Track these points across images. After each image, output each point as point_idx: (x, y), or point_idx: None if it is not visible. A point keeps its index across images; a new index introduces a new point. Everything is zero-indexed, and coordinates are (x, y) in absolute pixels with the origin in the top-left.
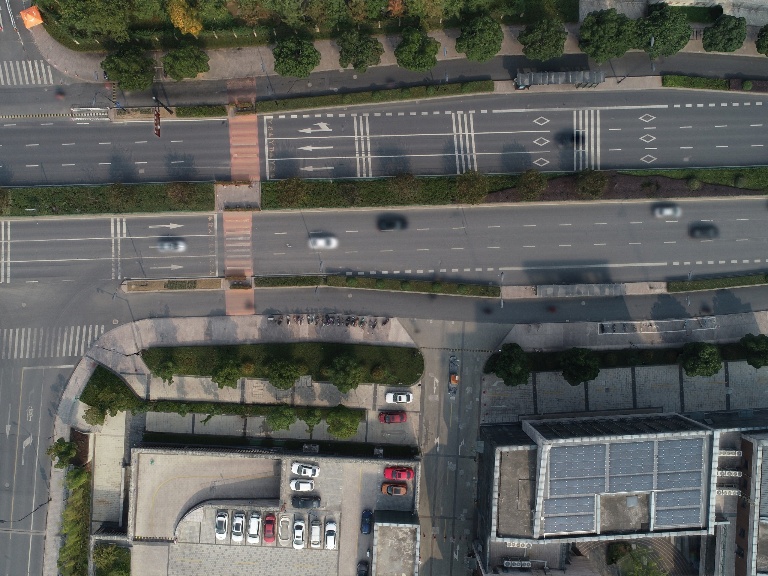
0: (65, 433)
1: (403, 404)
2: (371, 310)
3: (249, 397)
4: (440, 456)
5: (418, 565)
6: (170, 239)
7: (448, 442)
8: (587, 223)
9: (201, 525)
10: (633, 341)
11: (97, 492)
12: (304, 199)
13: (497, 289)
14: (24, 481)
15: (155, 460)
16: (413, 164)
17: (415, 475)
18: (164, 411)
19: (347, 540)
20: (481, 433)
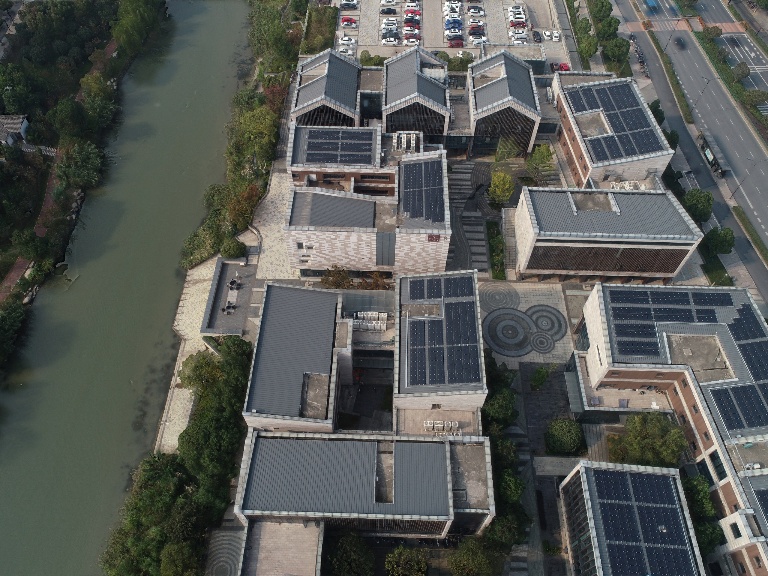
0: None
1: None
2: (652, 73)
3: None
4: None
5: None
6: (660, 5)
7: None
8: (759, 165)
9: (513, 5)
10: (687, 190)
11: None
12: (707, 45)
13: (693, 120)
14: None
15: None
16: (752, 88)
17: None
18: None
19: None
20: None
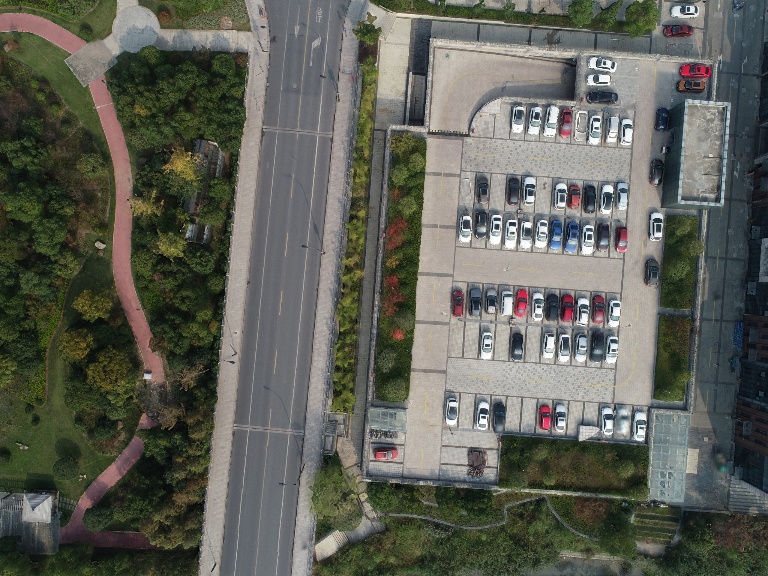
0: (354, 35)
1: (687, 20)
2: None
3: (536, 7)
4: (723, 73)
5: (727, 143)
6: None
7: (731, 59)
8: None
9: (495, 120)
10: None
11: (380, 101)
12: None
13: None
14: (312, 82)
15: (450, 55)
16: None
17: (712, 73)
18: (453, 15)
19: (640, 139)
20: (766, 49)
